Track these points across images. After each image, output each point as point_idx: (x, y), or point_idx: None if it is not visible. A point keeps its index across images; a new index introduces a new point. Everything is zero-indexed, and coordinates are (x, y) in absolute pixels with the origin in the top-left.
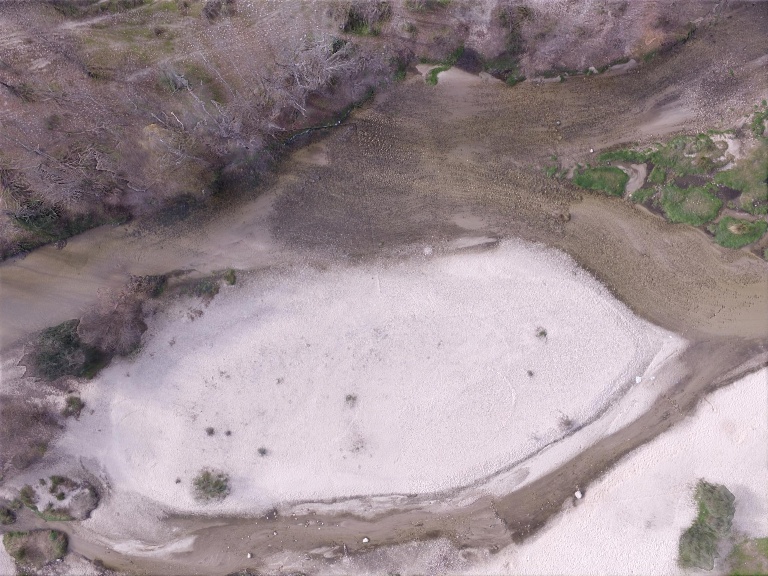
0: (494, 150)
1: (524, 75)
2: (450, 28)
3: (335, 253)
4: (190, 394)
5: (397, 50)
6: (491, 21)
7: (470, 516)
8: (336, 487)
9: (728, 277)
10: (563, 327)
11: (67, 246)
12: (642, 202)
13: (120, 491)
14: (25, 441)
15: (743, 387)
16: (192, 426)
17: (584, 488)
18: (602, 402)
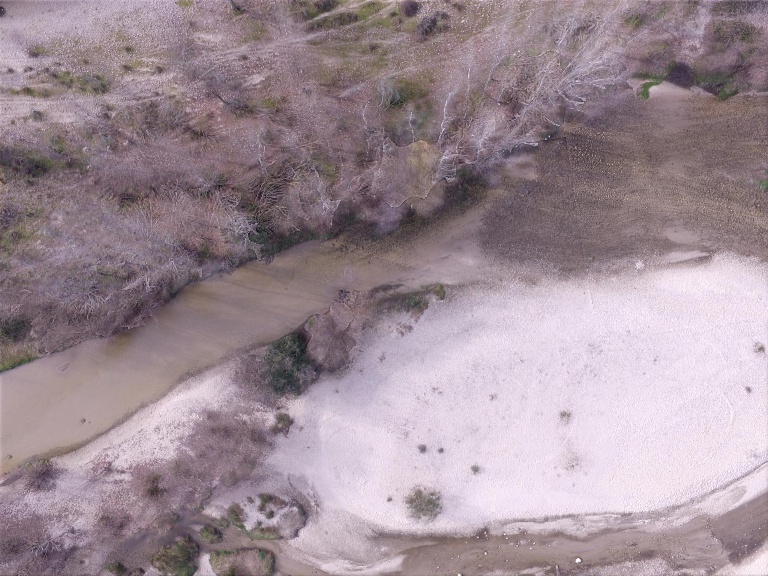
0: (706, 164)
1: (736, 89)
2: (664, 43)
3: (545, 268)
4: (402, 411)
5: None
6: (704, 36)
7: (685, 536)
8: (549, 506)
9: None
10: None
11: (274, 261)
12: None
13: (328, 509)
14: (233, 458)
15: None
16: (404, 443)
17: None
18: None
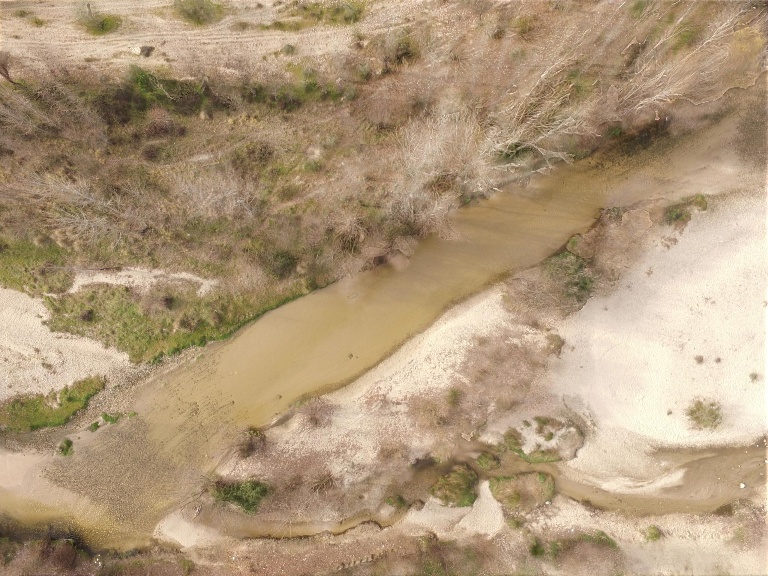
0: None
1: None
2: None
3: None
4: (675, 323)
5: None
6: None
7: None
8: None
9: None
10: None
11: (531, 183)
12: None
13: (606, 428)
14: (507, 383)
15: None
16: (680, 355)
17: None
18: None
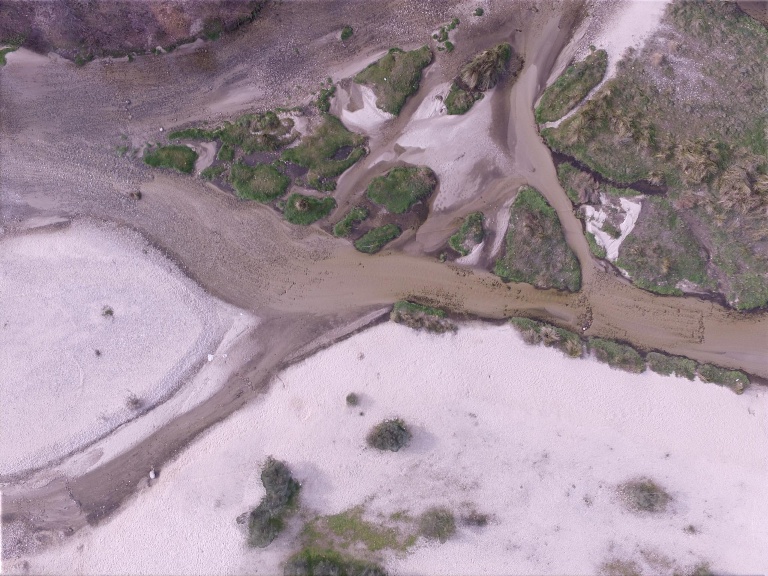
0: (65, 130)
1: (92, 55)
2: (11, 9)
3: None
4: None
5: None
6: (54, 1)
7: (45, 498)
8: None
9: (298, 254)
10: (130, 305)
11: None
12: (211, 180)
13: None
14: None
15: (313, 363)
16: None
17: (159, 468)
18: (173, 380)
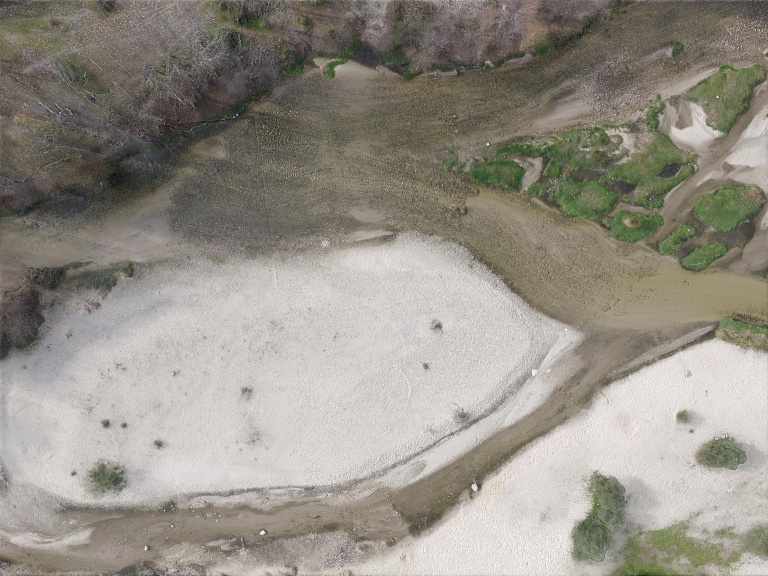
0: (391, 143)
1: (421, 69)
2: (345, 21)
3: (233, 246)
4: (86, 386)
5: (293, 43)
6: (387, 15)
7: (367, 508)
8: (233, 479)
9: (623, 270)
10: (458, 320)
11: None
12: (538, 195)
13: (16, 483)
14: None
15: (638, 380)
16: (88, 418)
17: (481, 480)
18: (498, 395)
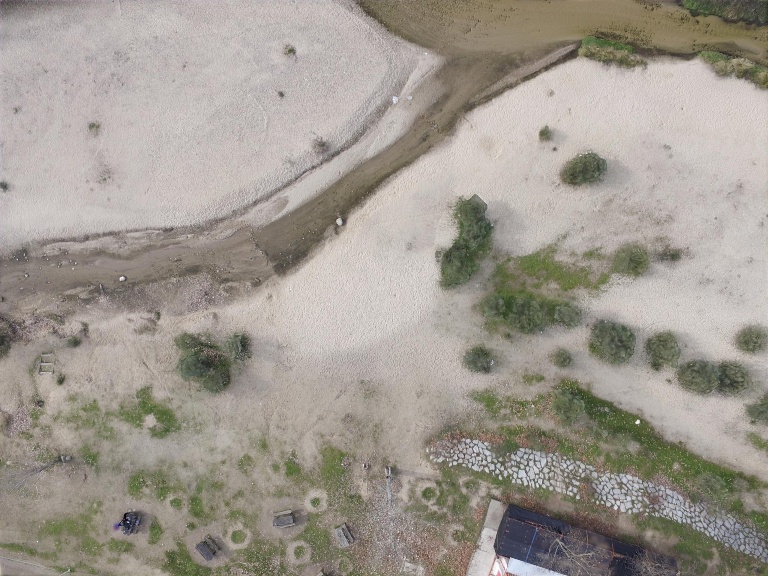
0: None
1: None
2: None
3: None
4: None
5: None
6: None
7: (230, 249)
8: (86, 222)
9: None
10: (313, 44)
11: None
12: None
13: None
14: None
15: (501, 103)
16: None
17: (345, 215)
18: (359, 124)
